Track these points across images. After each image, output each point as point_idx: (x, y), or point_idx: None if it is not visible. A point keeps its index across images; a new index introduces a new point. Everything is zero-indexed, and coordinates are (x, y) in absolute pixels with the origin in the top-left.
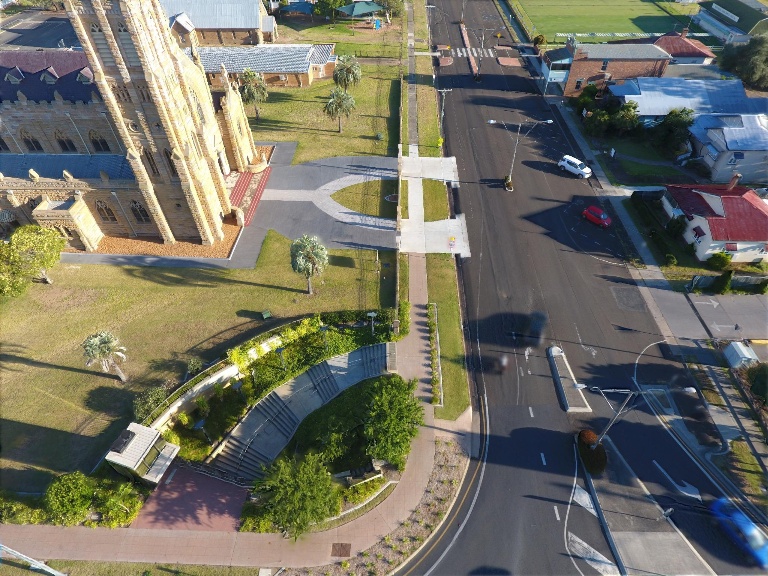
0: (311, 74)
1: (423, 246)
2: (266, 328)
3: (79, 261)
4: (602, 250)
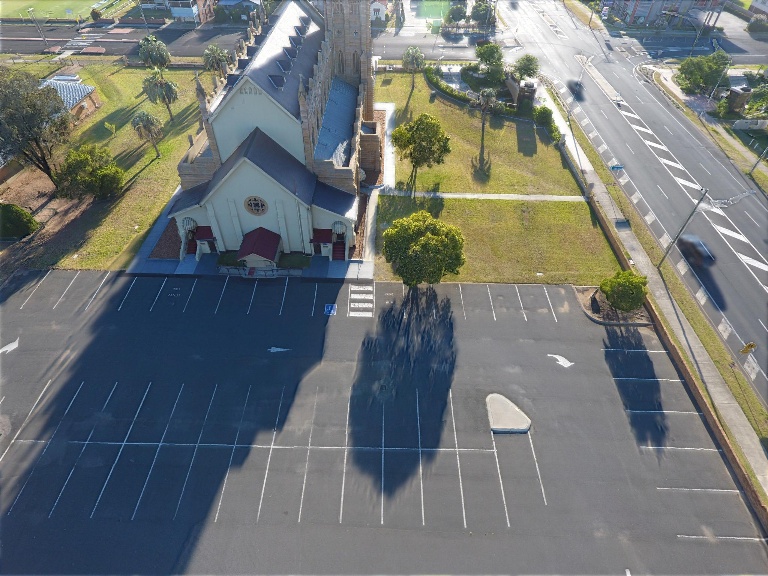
0: None
1: None
2: (441, 95)
3: (393, 158)
4: (376, 34)
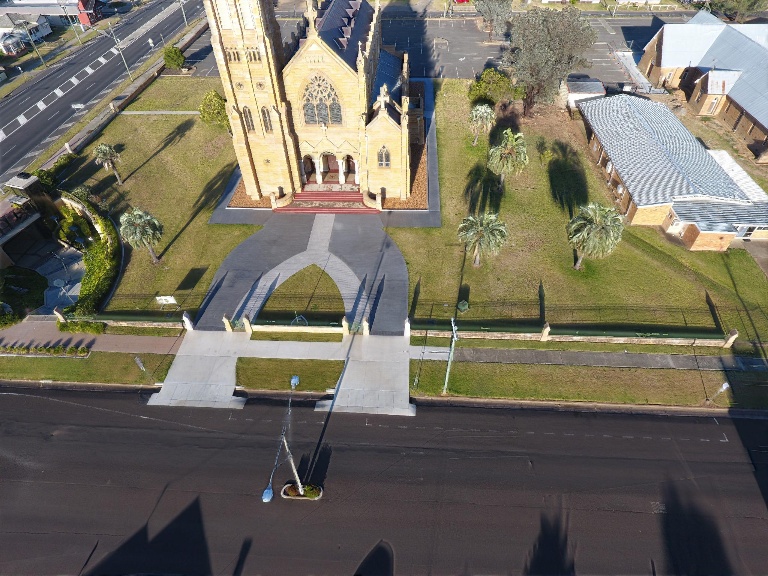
0: (658, 217)
1: (190, 353)
2: None
3: None
4: None
